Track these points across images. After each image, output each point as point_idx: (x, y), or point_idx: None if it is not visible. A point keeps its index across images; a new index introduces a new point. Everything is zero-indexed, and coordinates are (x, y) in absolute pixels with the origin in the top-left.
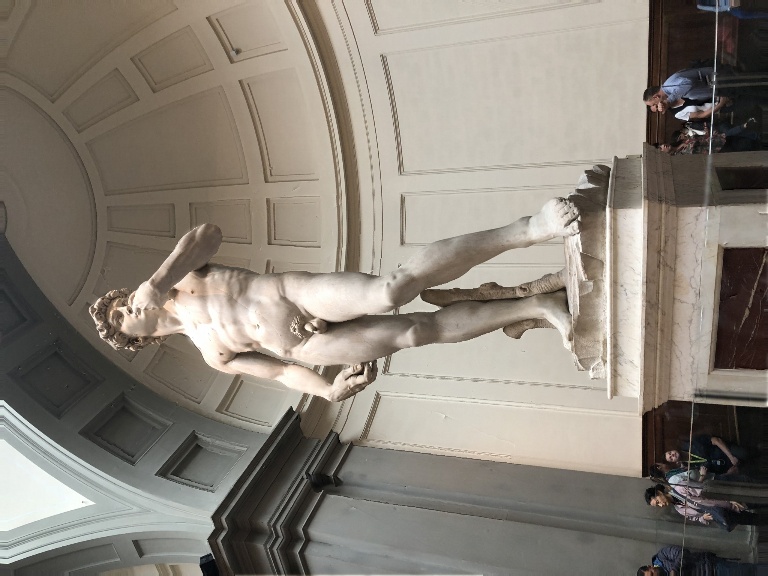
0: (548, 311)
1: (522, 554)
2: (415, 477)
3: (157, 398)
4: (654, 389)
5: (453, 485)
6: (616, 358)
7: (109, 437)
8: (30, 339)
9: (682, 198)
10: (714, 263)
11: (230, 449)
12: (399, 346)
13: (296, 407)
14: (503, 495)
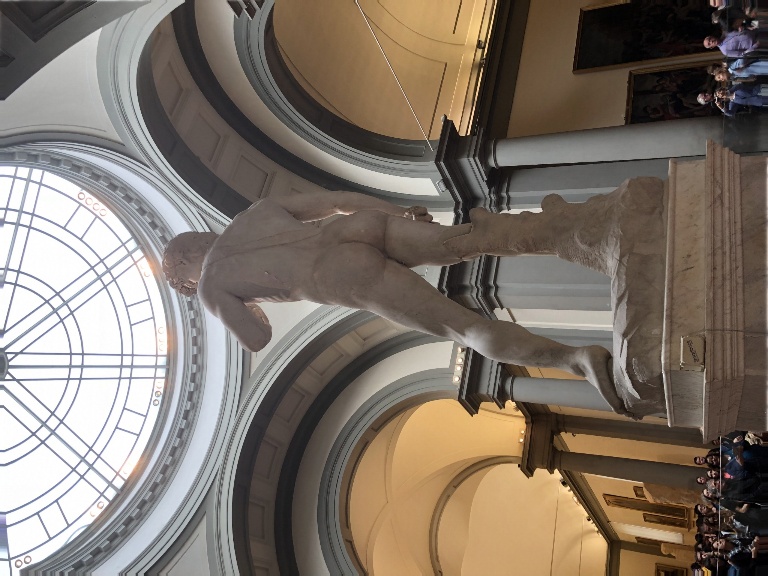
0: None
1: None
2: None
3: None
4: None
5: None
6: None
7: (34, 1)
8: None
9: None
10: None
11: None
12: None
13: None
14: None
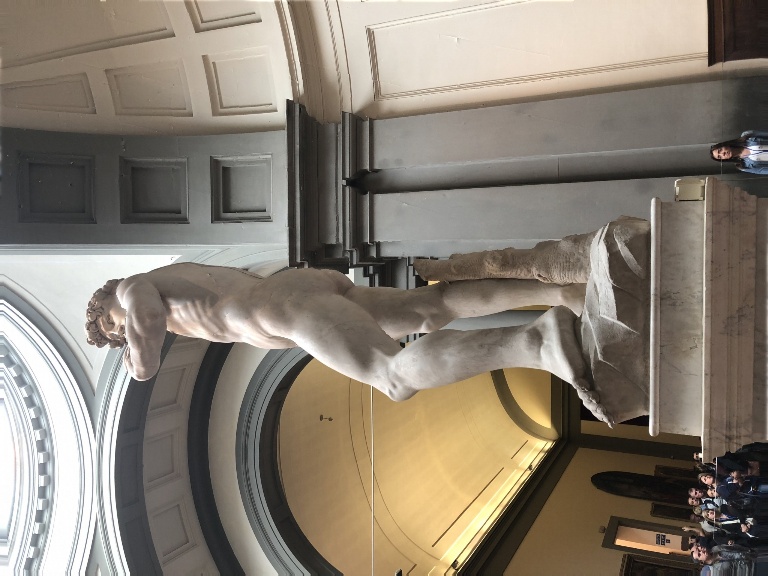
0: None
1: (581, 220)
2: (451, 149)
3: (152, 140)
4: None
5: (494, 150)
6: None
7: (146, 203)
8: None
9: (763, 408)
10: None
11: (256, 161)
12: None
13: (291, 94)
14: (549, 151)
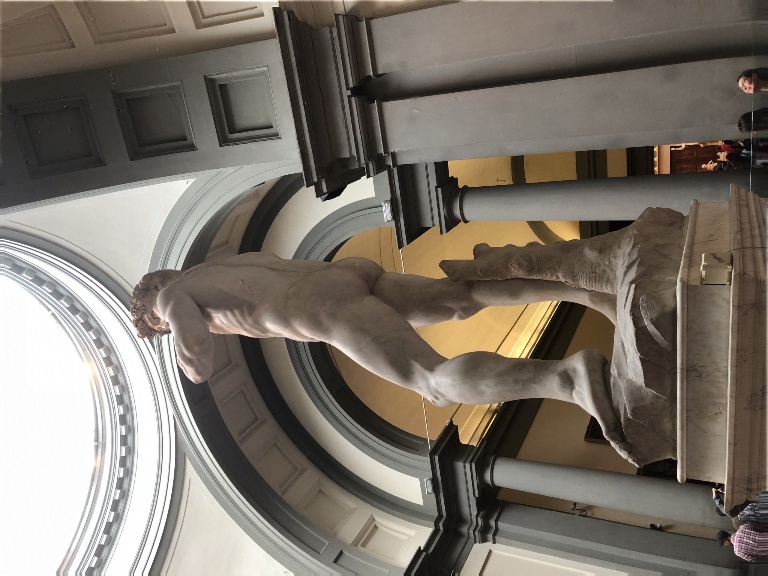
0: None
1: (603, 115)
2: (458, 46)
3: (140, 66)
4: None
5: (505, 45)
6: None
7: (149, 134)
8: None
9: None
10: None
11: (252, 75)
12: None
13: None
14: (565, 41)
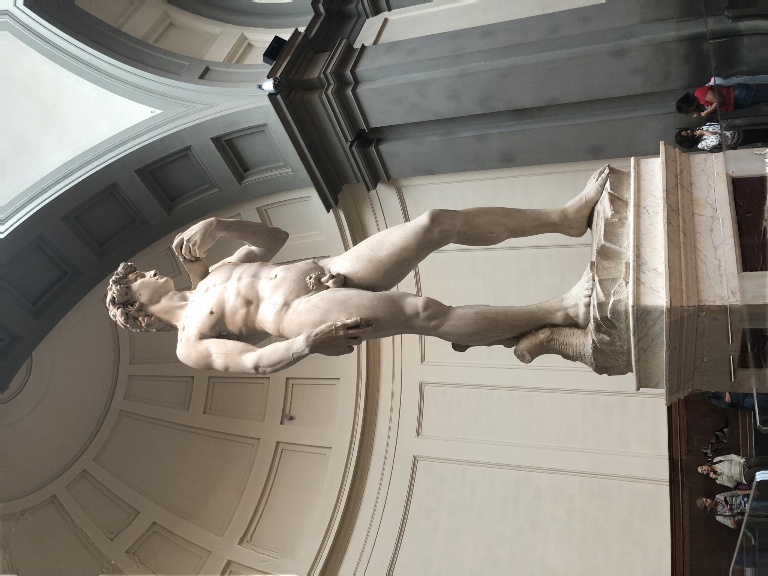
0: None
1: None
2: None
3: None
4: (681, 285)
5: None
6: (639, 267)
7: None
8: None
9: None
10: (725, 185)
11: None
12: (406, 307)
13: None
14: None
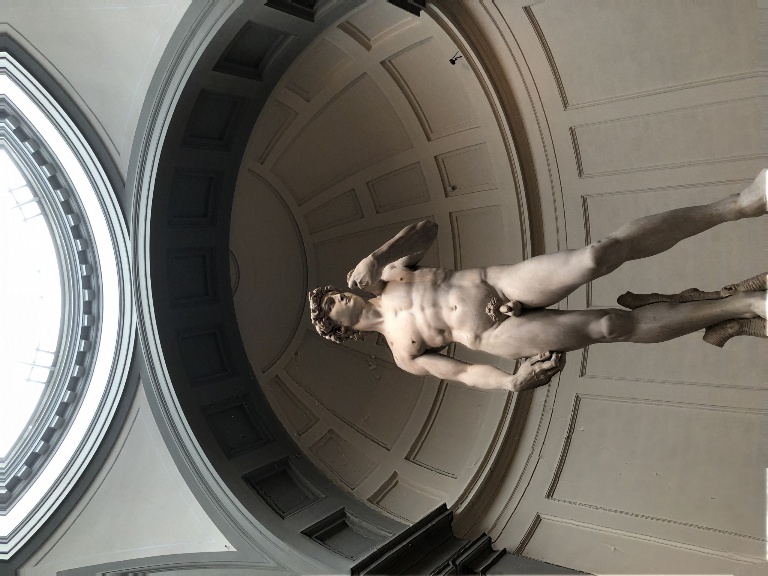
0: (756, 298)
1: None
2: None
3: (316, 471)
4: None
5: None
6: None
7: (266, 491)
8: (226, 386)
9: None
10: None
11: (376, 532)
12: (591, 333)
13: (450, 506)
14: None
